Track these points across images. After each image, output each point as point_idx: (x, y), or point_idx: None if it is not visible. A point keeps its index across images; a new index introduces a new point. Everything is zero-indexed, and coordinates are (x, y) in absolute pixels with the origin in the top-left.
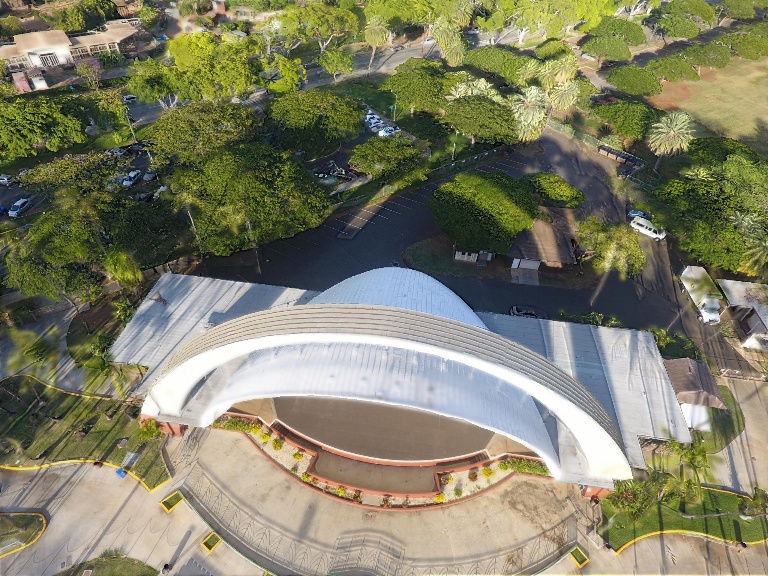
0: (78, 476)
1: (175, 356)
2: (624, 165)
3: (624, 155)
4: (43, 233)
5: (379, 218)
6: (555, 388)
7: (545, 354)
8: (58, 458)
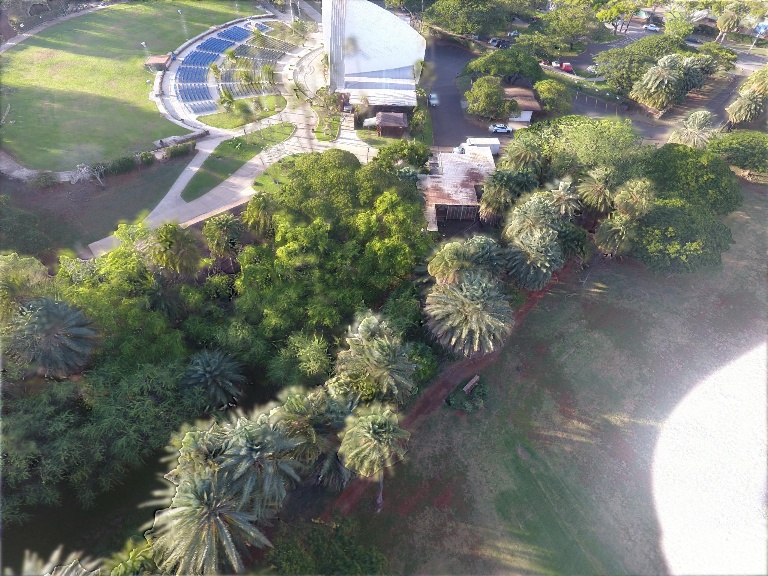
0: None
1: None
2: None
3: None
4: None
5: None
6: (334, 10)
7: (391, 78)
8: None
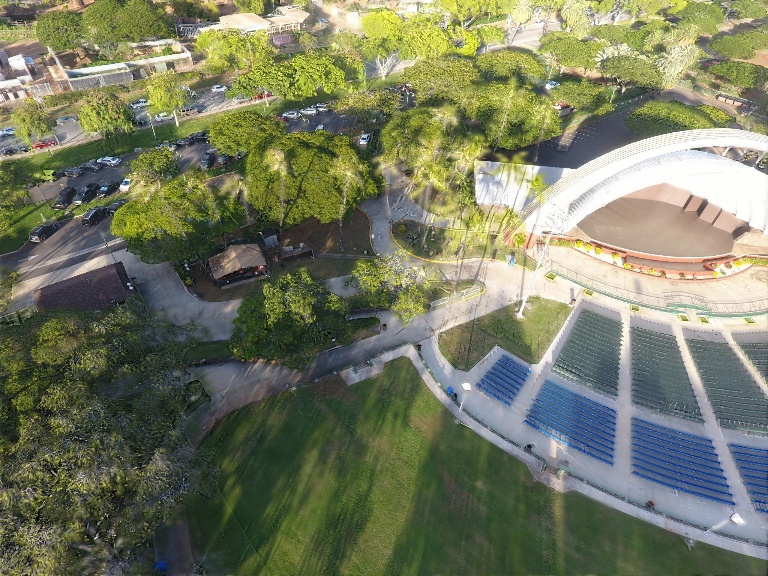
0: (484, 266)
1: (561, 181)
2: (740, 108)
3: (740, 100)
4: (414, 126)
5: (579, 139)
6: None
7: None
8: (465, 258)
